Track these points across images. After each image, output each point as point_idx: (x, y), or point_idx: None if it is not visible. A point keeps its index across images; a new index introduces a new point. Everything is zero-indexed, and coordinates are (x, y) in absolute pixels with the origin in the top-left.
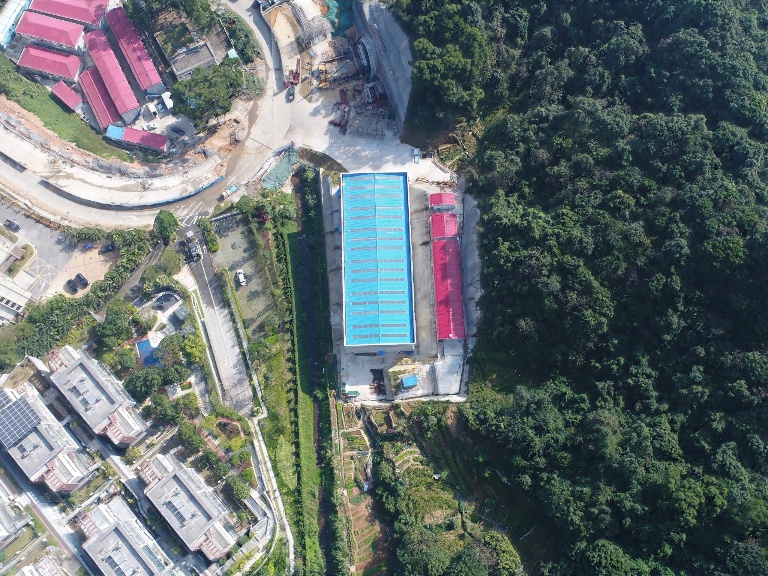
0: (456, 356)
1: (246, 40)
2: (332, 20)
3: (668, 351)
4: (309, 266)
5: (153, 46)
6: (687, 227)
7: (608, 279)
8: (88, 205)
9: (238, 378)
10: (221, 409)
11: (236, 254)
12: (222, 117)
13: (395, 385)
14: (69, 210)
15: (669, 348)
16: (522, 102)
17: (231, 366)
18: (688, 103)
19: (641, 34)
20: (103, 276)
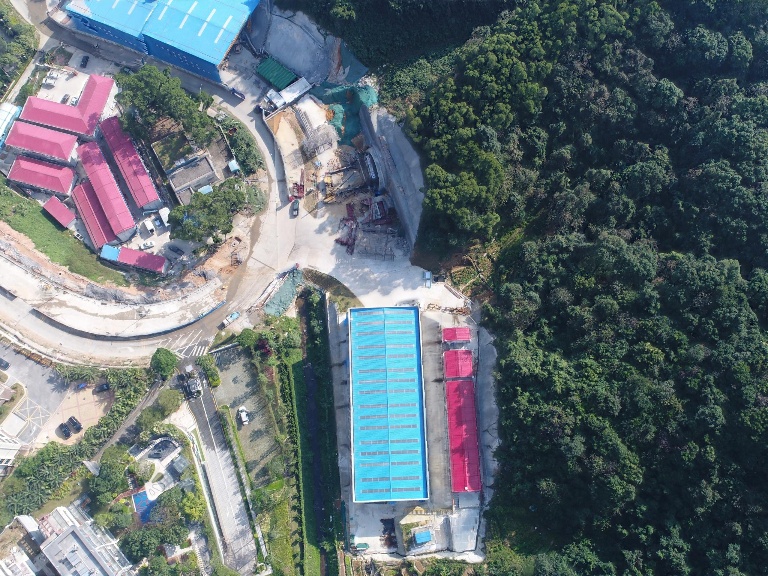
0: (472, 509)
1: (248, 151)
2: (338, 127)
3: (701, 523)
4: (315, 399)
5: (150, 157)
6: (722, 392)
7: (636, 443)
8: (82, 336)
9: (240, 530)
10: (222, 573)
11: (238, 389)
12: (223, 235)
13: (407, 540)
14: (62, 342)
15: (702, 520)
16: (540, 222)
17: (233, 516)
18: (720, 243)
19: (667, 160)
20: (97, 419)
